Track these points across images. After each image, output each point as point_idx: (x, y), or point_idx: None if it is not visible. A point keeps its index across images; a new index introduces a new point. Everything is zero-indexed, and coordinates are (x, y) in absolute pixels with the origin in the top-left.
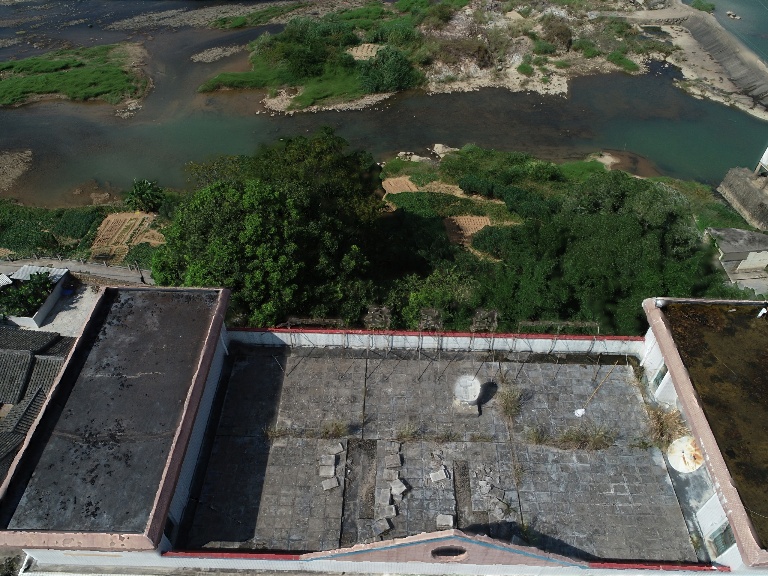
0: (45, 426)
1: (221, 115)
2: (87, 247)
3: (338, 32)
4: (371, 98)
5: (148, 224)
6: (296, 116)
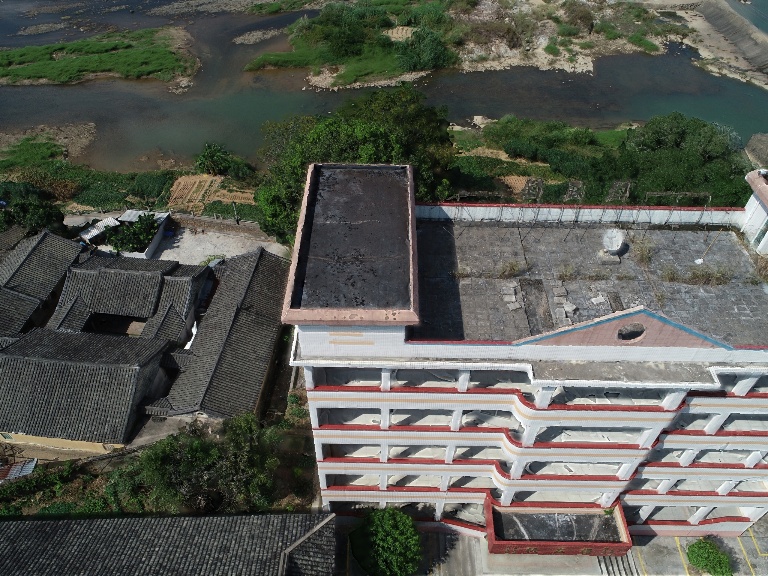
0: (301, 253)
1: (269, 91)
2: (164, 205)
3: (373, 15)
4: (409, 76)
5: (217, 185)
6: (340, 92)
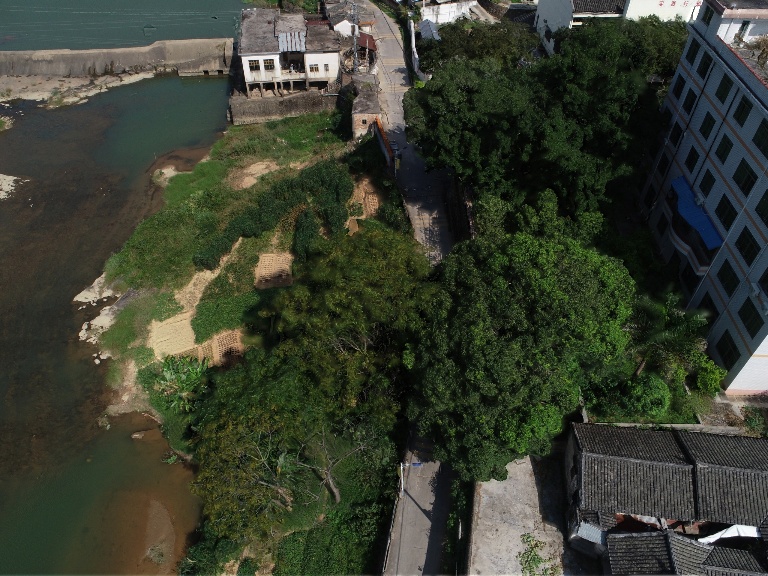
0: None
1: None
2: None
3: None
4: None
5: None
6: None
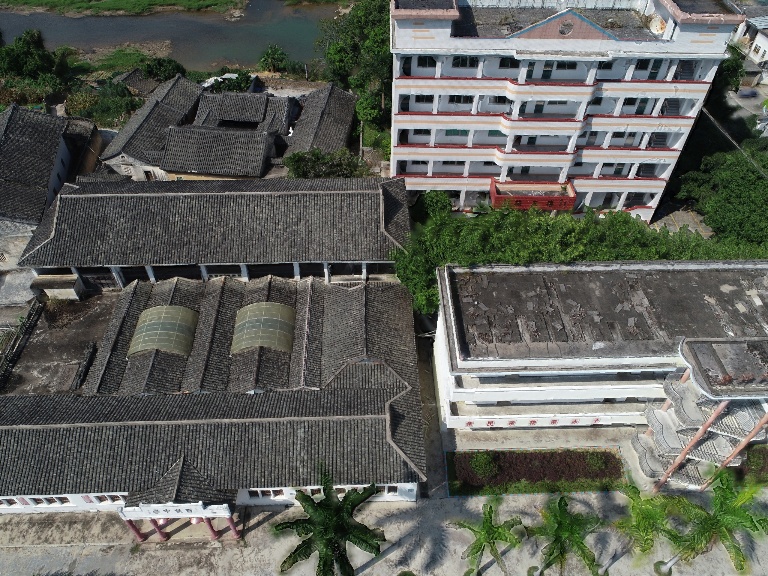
0: None
1: (307, 20)
2: None
3: None
4: None
5: None
6: None
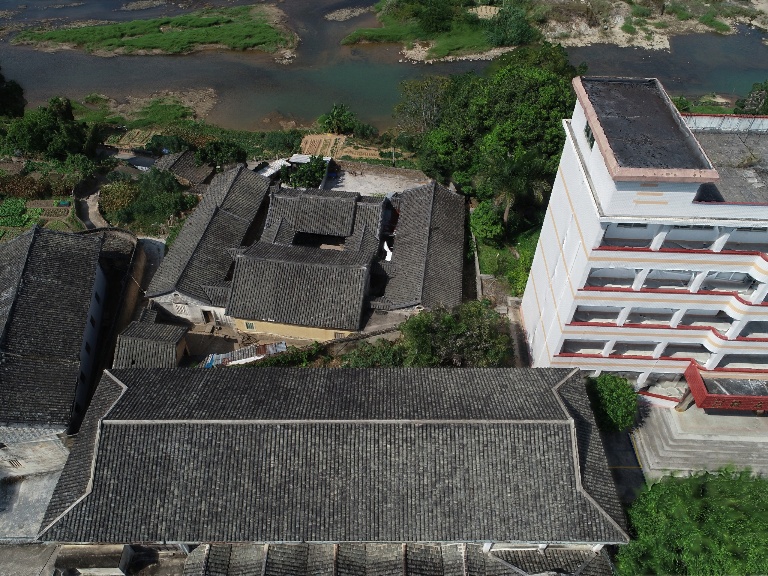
0: None
1: (368, 63)
2: None
3: None
4: (497, 51)
5: (343, 143)
6: (435, 64)
